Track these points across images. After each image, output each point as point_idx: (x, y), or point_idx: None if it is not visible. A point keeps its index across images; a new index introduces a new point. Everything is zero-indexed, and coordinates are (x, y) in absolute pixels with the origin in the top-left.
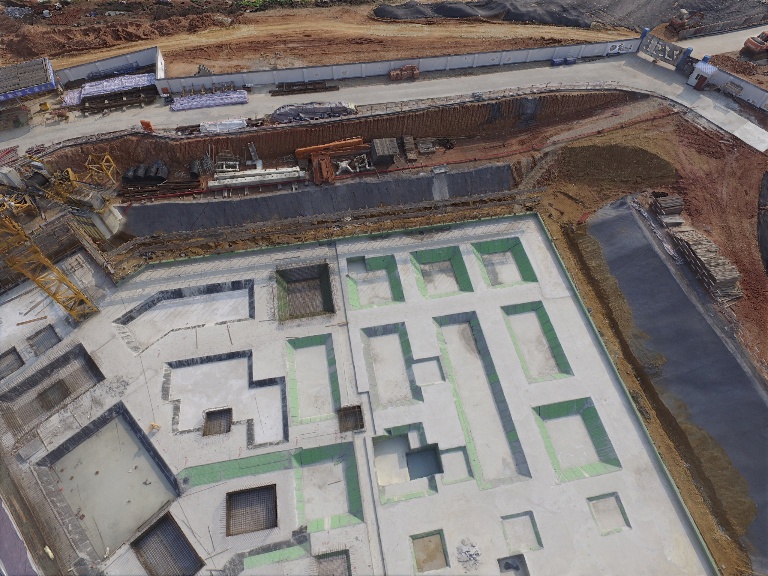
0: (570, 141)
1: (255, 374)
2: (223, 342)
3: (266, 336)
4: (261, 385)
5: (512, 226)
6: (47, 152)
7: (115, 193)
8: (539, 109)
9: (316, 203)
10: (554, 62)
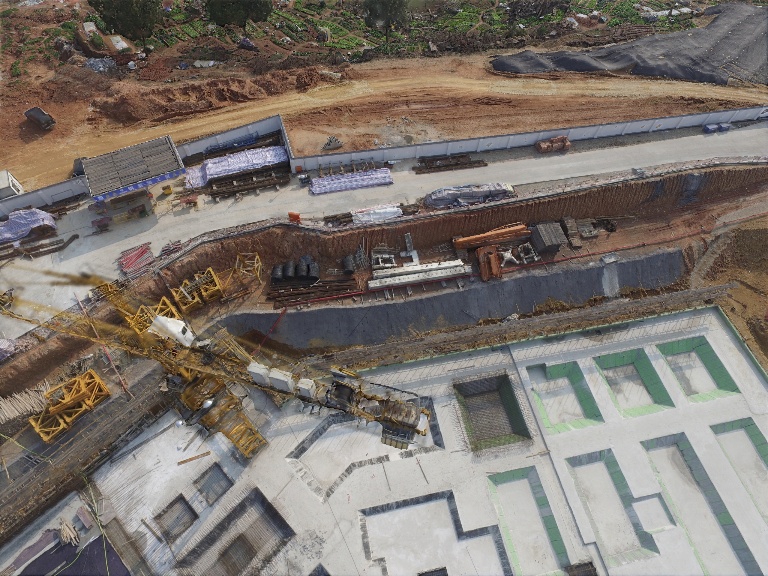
0: (742, 222)
1: (464, 523)
2: (417, 481)
3: (463, 472)
4: (471, 536)
5: (694, 322)
6: (186, 251)
7: (264, 296)
8: (703, 185)
9: (482, 301)
10: (708, 129)
